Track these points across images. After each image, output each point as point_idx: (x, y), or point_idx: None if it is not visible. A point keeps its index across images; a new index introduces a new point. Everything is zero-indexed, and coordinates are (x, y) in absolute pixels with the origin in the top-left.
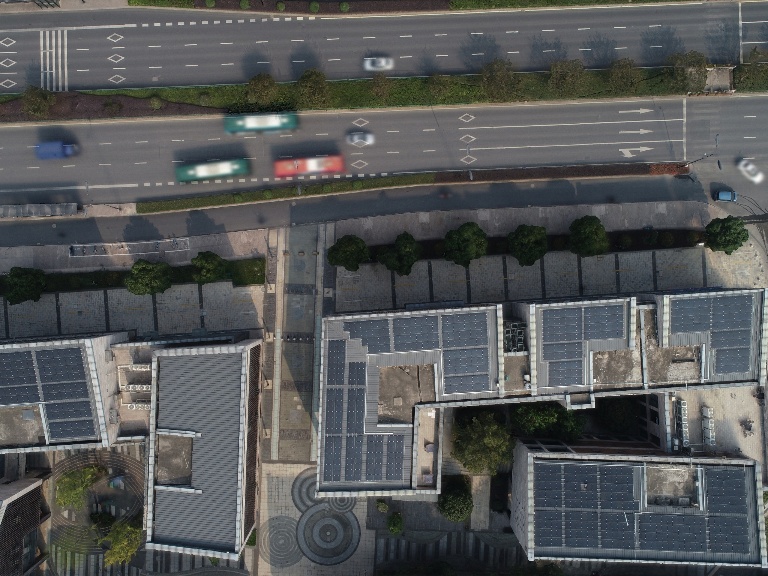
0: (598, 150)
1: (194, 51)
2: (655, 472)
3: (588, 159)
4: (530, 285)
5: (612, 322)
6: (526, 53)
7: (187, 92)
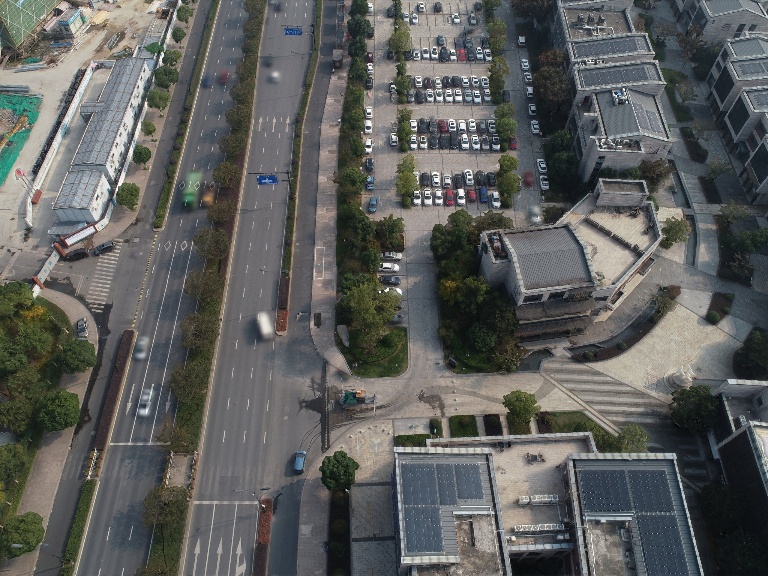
0: None
1: None
2: (599, 569)
3: None
4: None
5: None
6: None
7: None
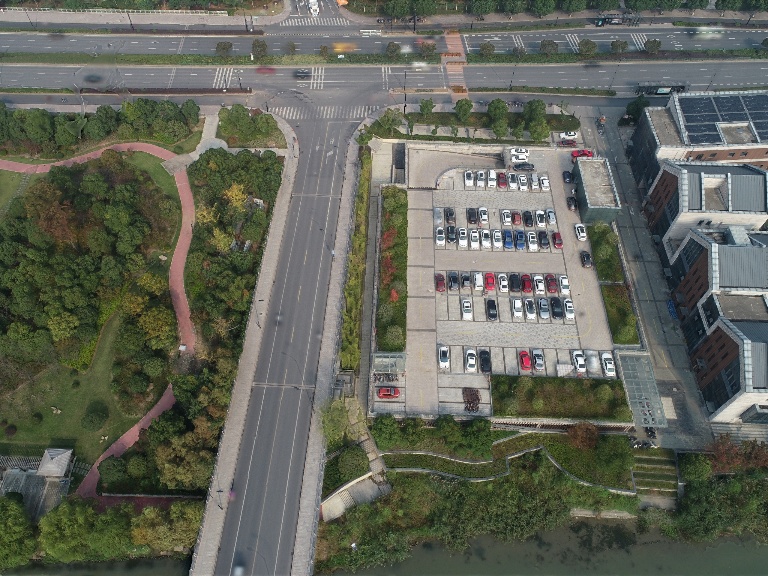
0: None
1: (716, 41)
2: None
3: None
4: None
5: None
6: None
7: (722, 51)
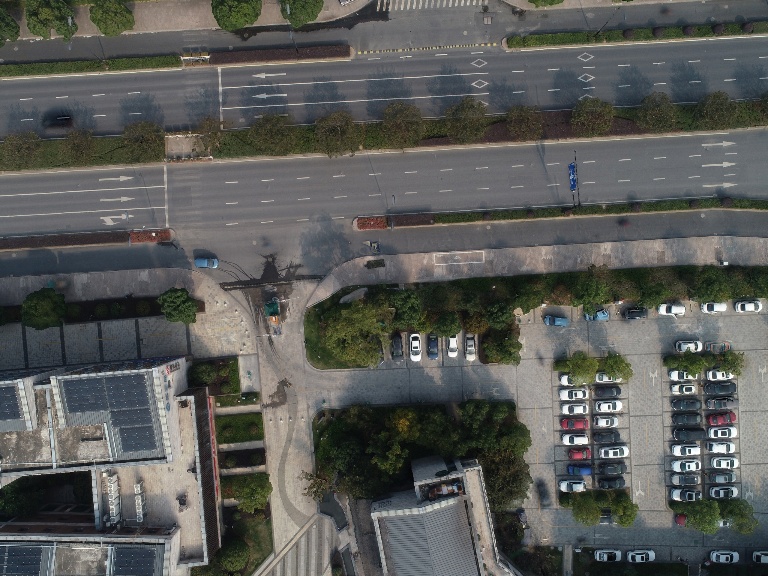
0: (79, 218)
1: None
2: (68, 551)
3: (69, 228)
4: (12, 355)
5: (6, 403)
6: (4, 122)
7: None
